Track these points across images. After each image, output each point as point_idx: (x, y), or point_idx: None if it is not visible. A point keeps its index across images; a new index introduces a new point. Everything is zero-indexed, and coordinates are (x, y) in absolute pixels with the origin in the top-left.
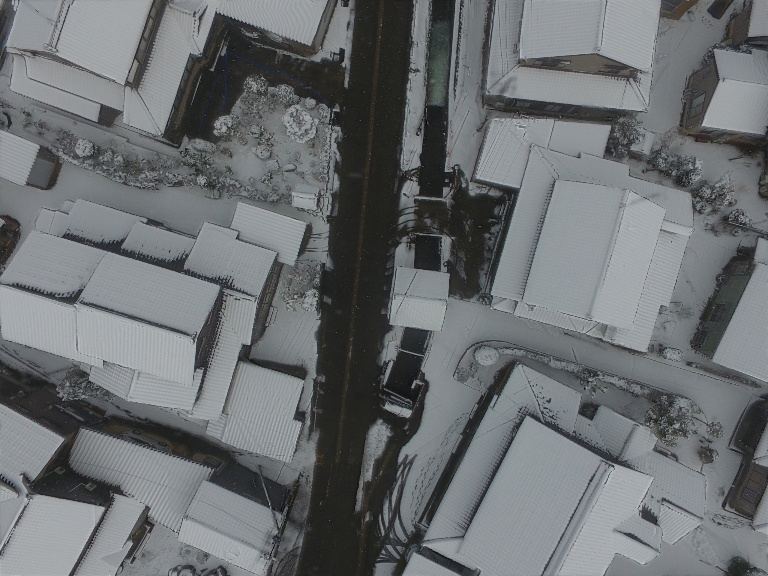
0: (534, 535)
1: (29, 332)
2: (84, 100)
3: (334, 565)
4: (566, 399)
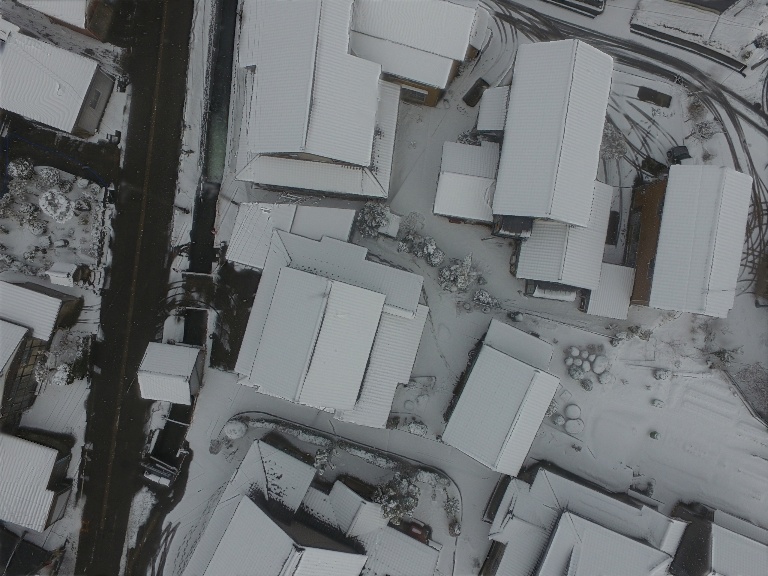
0: None
1: None
2: None
3: None
4: (298, 475)
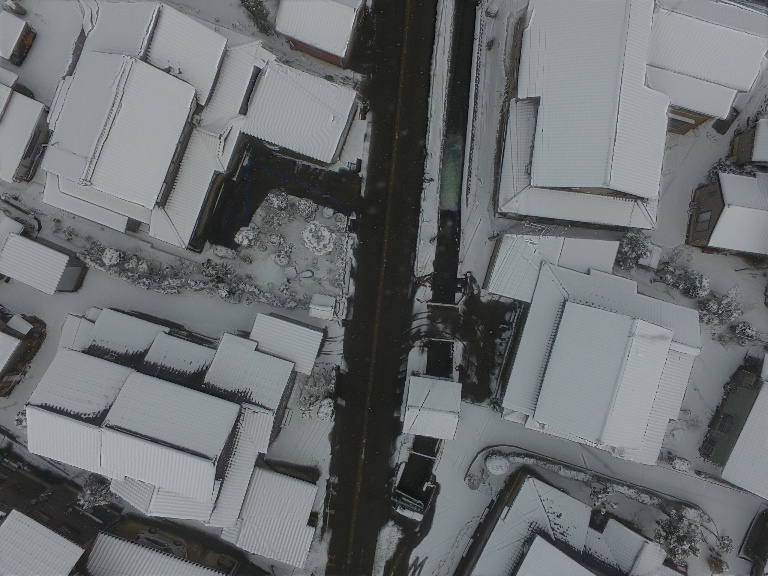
0: None
1: (55, 447)
2: (112, 213)
3: None
4: (576, 514)
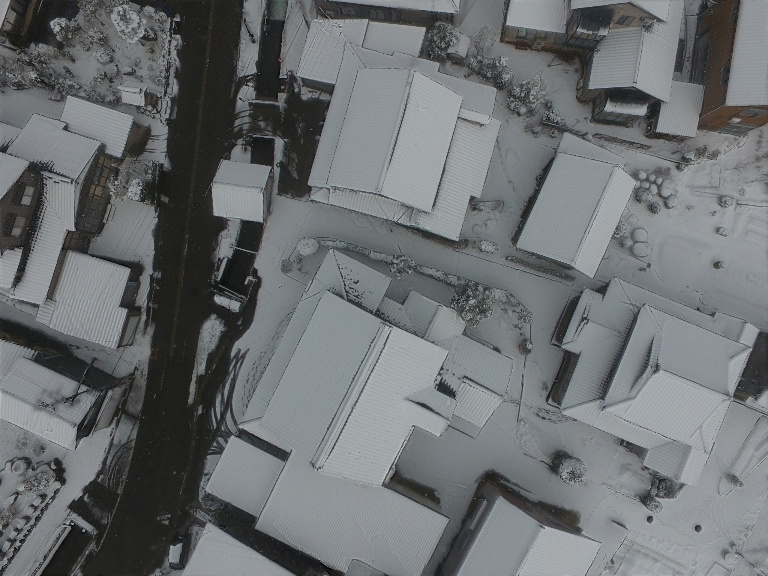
0: (322, 399)
1: None
2: None
3: (167, 457)
4: (374, 282)
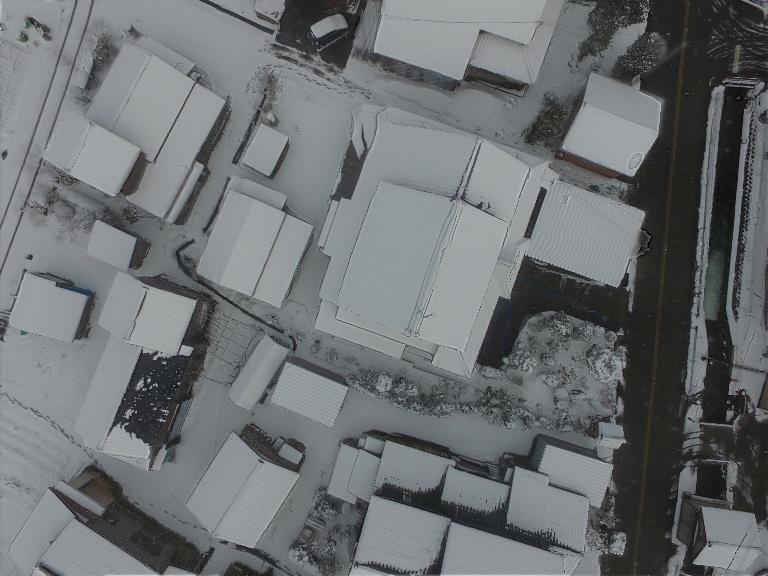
0: None
1: None
2: (390, 340)
3: None
4: None
